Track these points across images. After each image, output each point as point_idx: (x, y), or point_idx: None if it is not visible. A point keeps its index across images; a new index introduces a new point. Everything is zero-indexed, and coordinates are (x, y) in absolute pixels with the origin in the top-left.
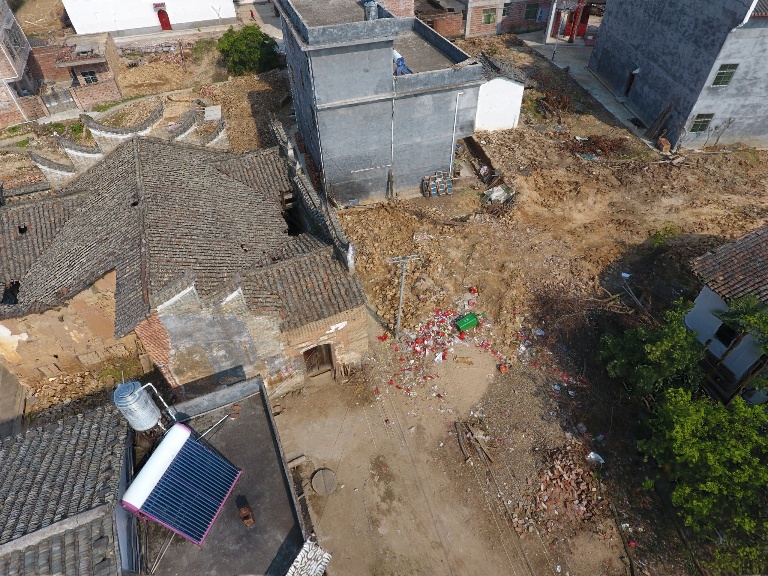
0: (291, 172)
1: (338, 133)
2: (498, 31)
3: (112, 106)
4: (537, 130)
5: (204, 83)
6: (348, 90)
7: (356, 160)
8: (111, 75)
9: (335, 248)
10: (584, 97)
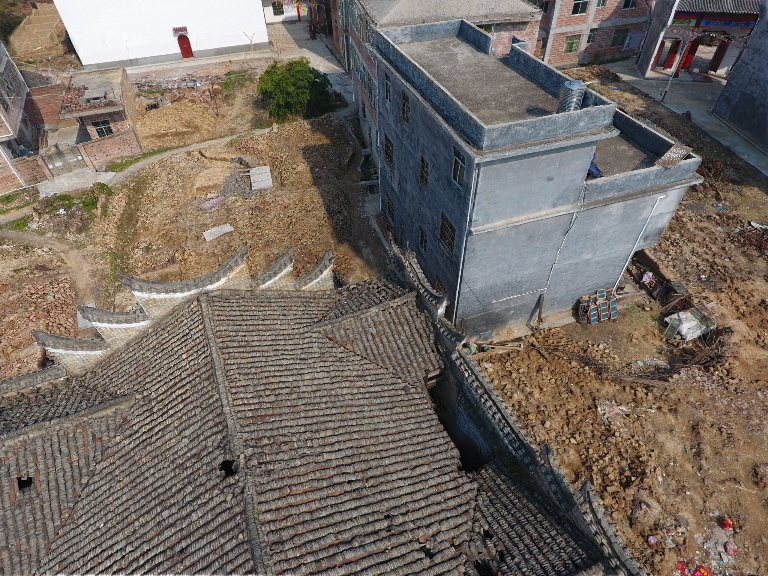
0: (439, 337)
1: (489, 259)
2: (580, 60)
3: (130, 164)
4: (693, 210)
5: (241, 130)
6: (519, 205)
7: (503, 288)
8: (129, 124)
9: (607, 571)
10: (730, 158)
